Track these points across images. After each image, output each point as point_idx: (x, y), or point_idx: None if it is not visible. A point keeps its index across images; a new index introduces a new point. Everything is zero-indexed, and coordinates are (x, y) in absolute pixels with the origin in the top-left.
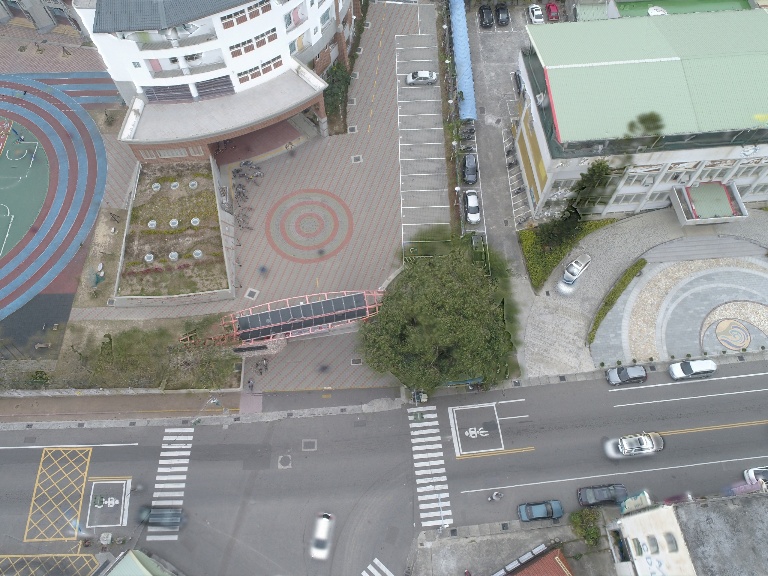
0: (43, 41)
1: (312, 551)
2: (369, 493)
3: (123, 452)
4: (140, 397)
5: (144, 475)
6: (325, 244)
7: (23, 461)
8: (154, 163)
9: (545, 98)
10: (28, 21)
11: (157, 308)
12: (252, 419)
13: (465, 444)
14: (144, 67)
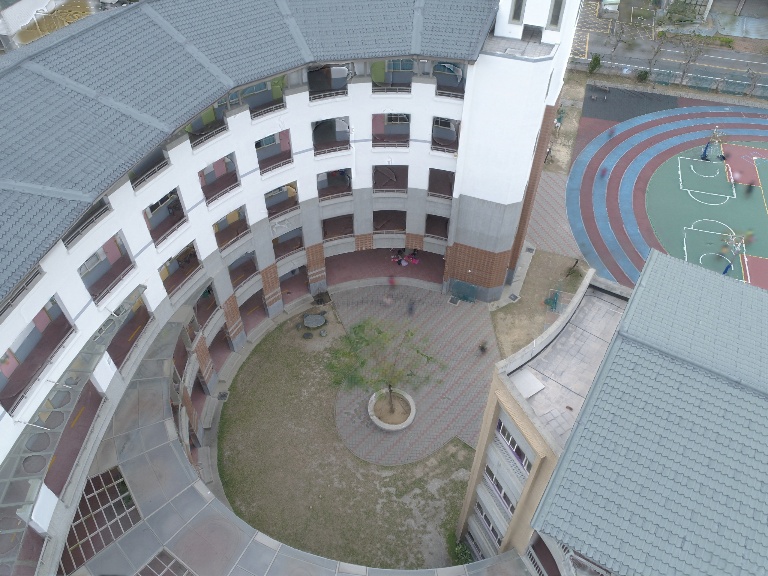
0: None
1: None
2: None
3: None
4: None
5: None
6: None
7: None
8: None
9: None
10: None
11: None
12: None
13: None
14: None
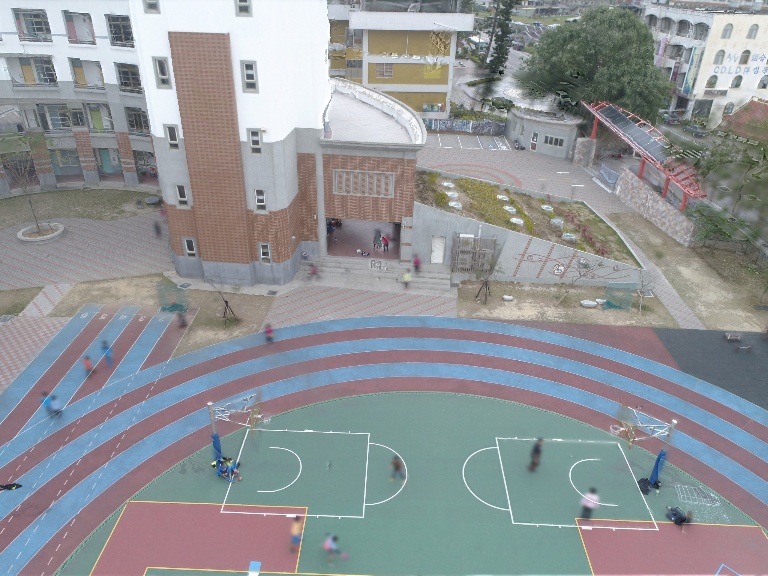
0: None
1: None
2: None
3: None
4: None
5: None
6: (493, 175)
7: None
8: None
9: None
10: None
11: None
12: (724, 212)
13: None
14: None
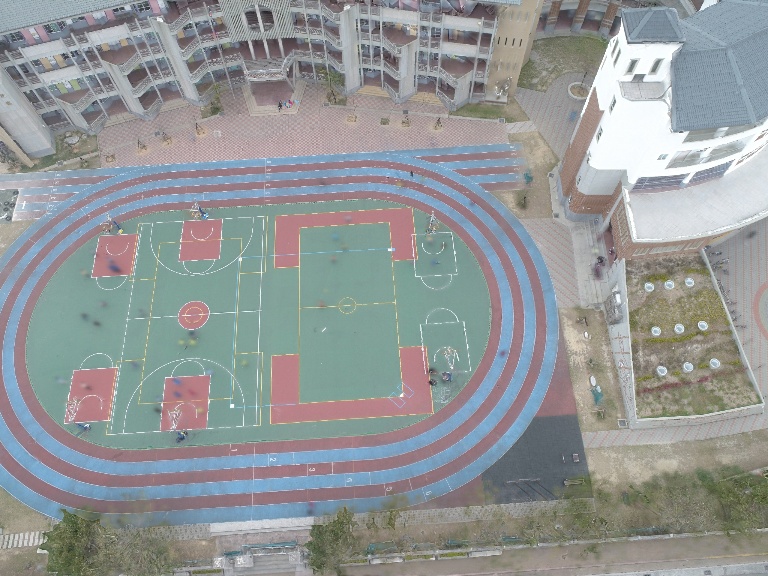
0: (404, 111)
1: None
2: None
3: None
4: (704, 539)
5: None
6: None
7: None
8: (637, 259)
9: None
10: (380, 89)
11: (679, 428)
12: None
13: None
14: (668, 159)
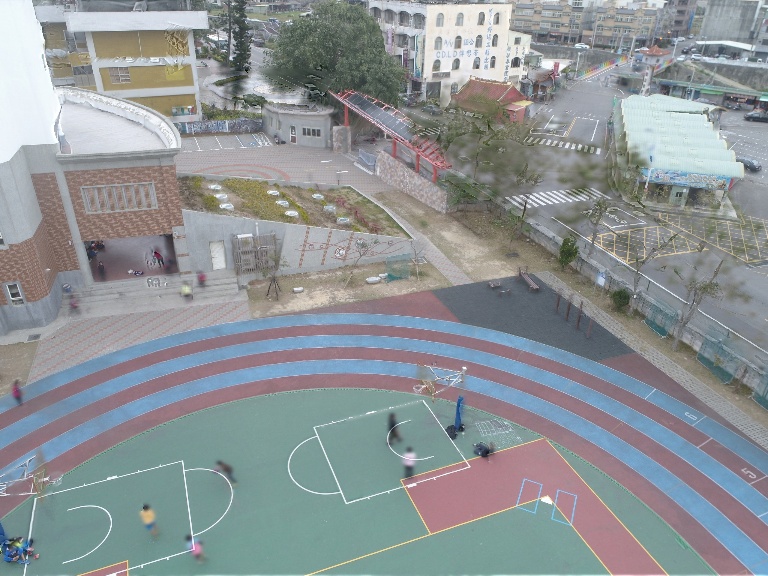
0: None
1: (532, 152)
2: (474, 142)
3: (568, 221)
4: None
5: (571, 207)
6: (260, 172)
7: (658, 271)
8: None
9: None
10: None
11: None
12: (468, 179)
13: (411, 125)
14: (46, 66)
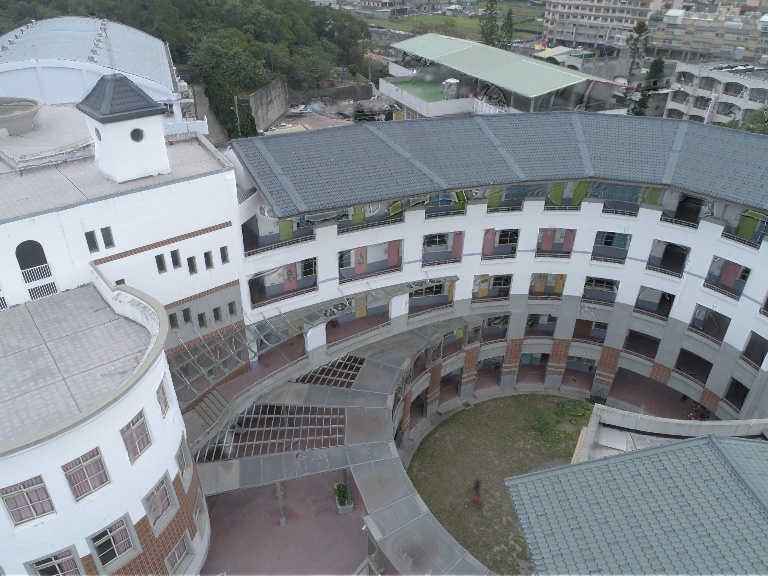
0: None
1: None
2: None
3: None
4: None
5: None
6: None
7: None
8: None
9: (593, 96)
10: None
11: None
12: None
13: None
14: None
